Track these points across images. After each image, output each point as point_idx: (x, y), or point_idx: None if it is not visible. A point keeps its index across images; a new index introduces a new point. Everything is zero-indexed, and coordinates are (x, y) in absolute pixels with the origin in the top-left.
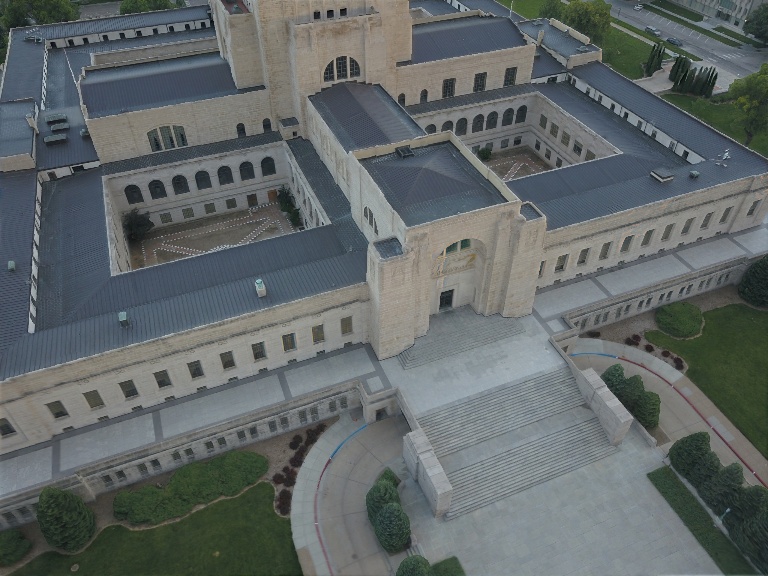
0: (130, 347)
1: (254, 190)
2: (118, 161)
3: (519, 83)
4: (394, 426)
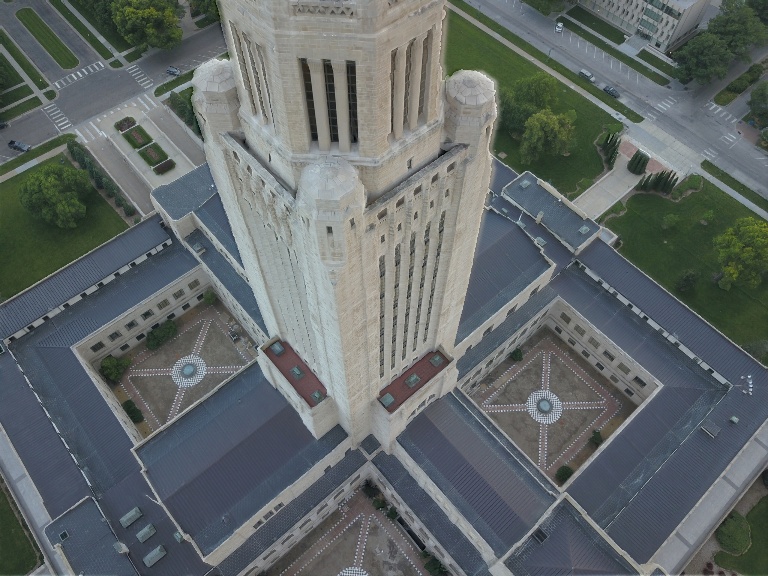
0: None
1: None
2: (229, 555)
3: (540, 290)
4: None
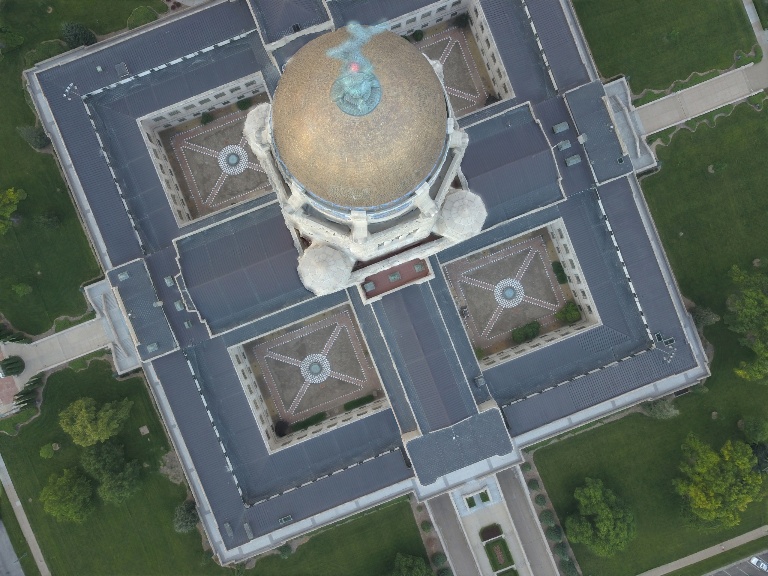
0: None
1: None
2: None
3: None
4: None
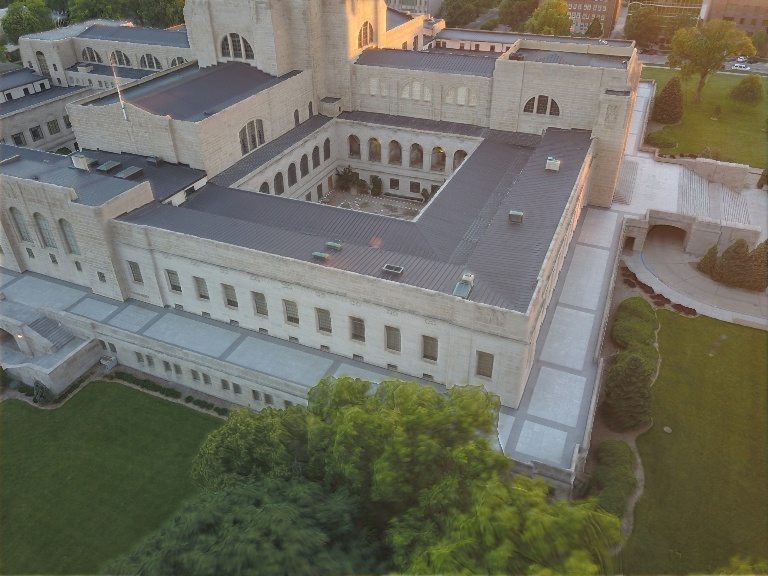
0: (562, 222)
1: (321, 178)
2: (220, 173)
3: None
4: (653, 246)
